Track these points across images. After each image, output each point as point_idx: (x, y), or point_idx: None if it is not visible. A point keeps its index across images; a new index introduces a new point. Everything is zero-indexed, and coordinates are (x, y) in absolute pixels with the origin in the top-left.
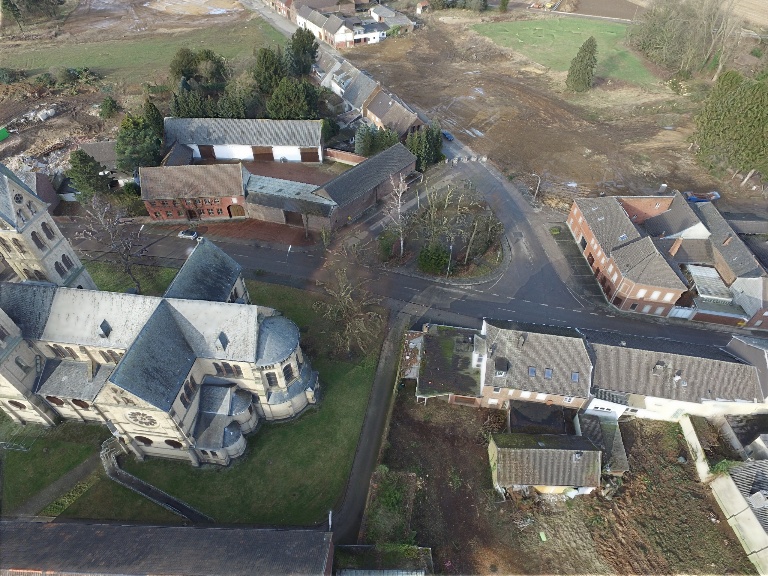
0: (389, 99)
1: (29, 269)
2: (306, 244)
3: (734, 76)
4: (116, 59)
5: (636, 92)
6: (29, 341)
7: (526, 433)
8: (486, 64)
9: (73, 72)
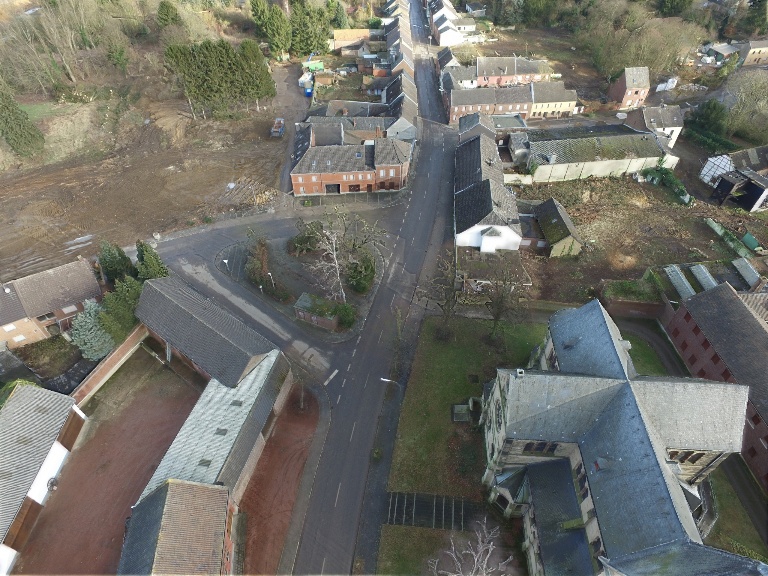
0: None
1: None
2: (315, 408)
3: (177, 48)
4: None
5: (64, 121)
6: None
7: (542, 231)
8: None
9: None
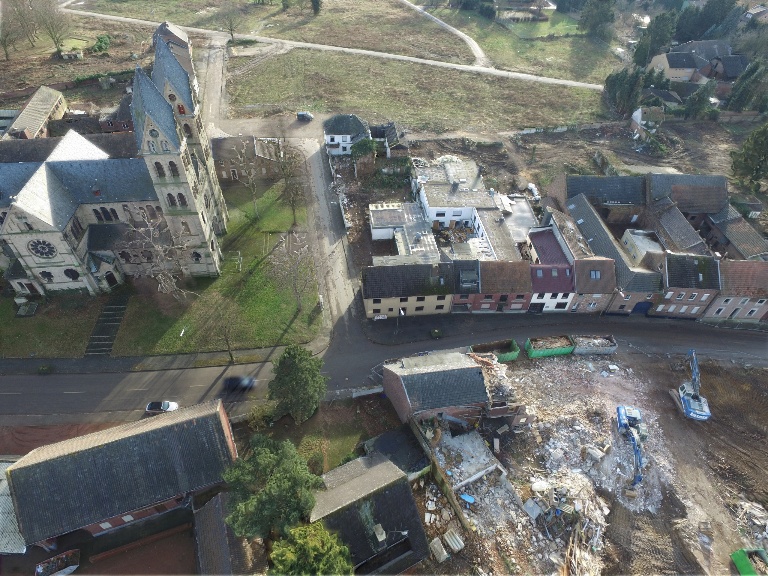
0: None
1: None
2: None
3: None
4: None
5: None
6: None
7: None
8: None
9: None
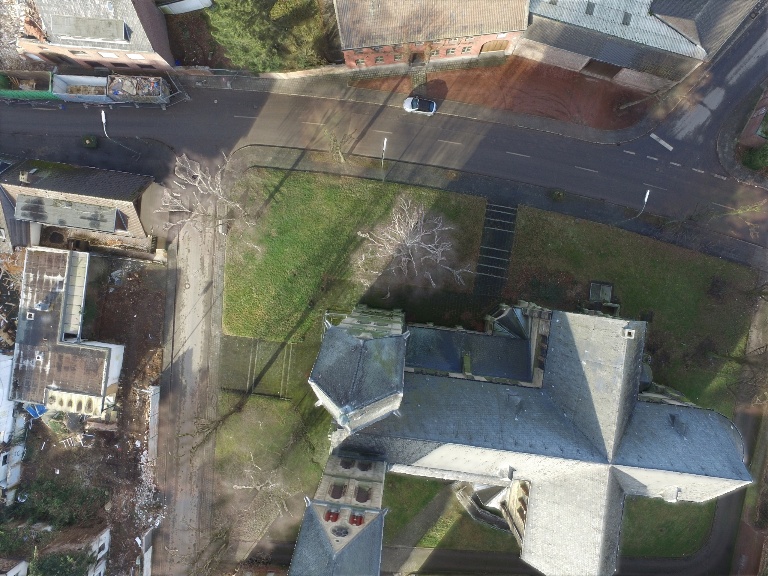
0: None
1: None
2: (620, 124)
3: None
4: None
5: None
6: None
7: None
8: None
9: None
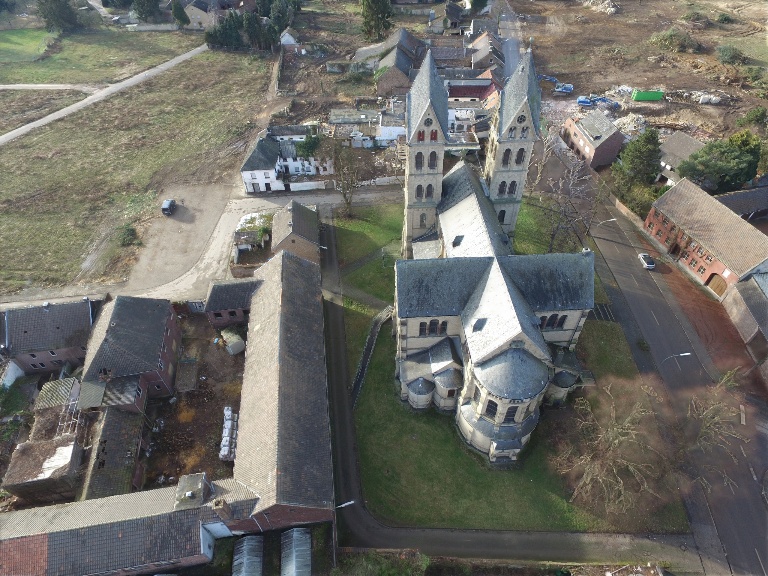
0: None
1: (489, 173)
2: None
3: None
4: None
5: None
6: None
7: None
8: None
9: None
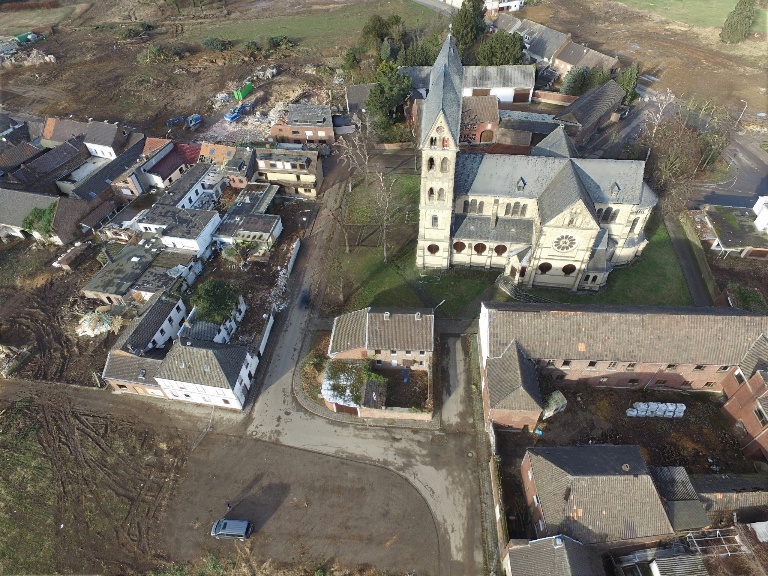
0: (582, 48)
1: None
2: None
3: None
4: (296, 30)
5: None
6: (456, 197)
7: None
8: (629, 24)
9: (276, 40)
